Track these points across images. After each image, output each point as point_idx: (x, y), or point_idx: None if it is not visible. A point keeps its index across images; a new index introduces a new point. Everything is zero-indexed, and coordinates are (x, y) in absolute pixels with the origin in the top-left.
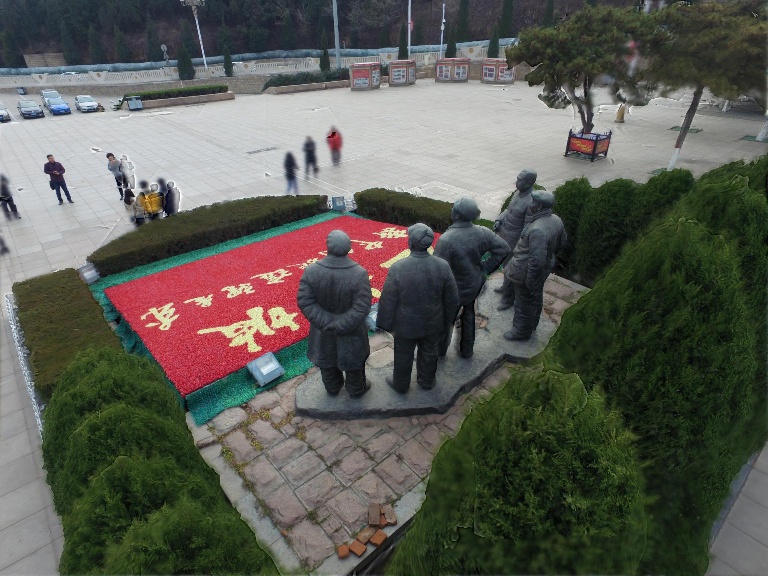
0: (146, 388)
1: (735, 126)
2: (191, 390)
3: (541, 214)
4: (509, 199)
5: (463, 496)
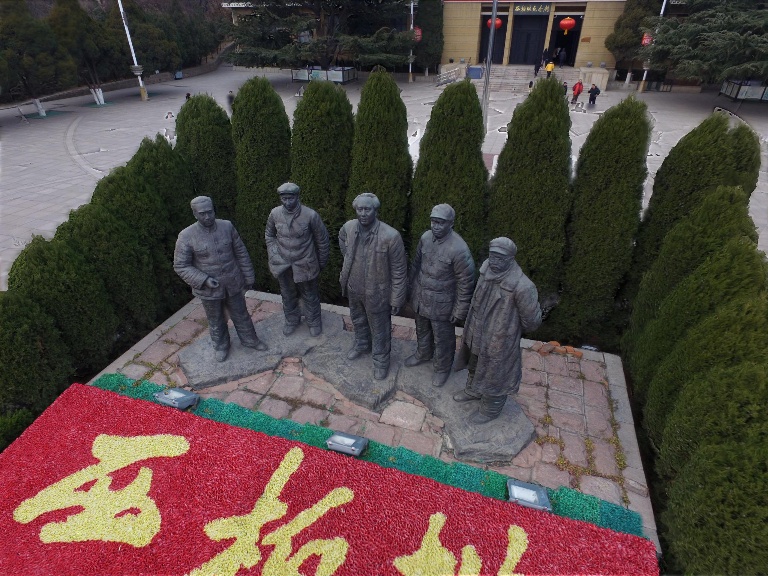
0: (724, 376)
1: None
2: (640, 538)
3: None
4: None
5: (647, 132)
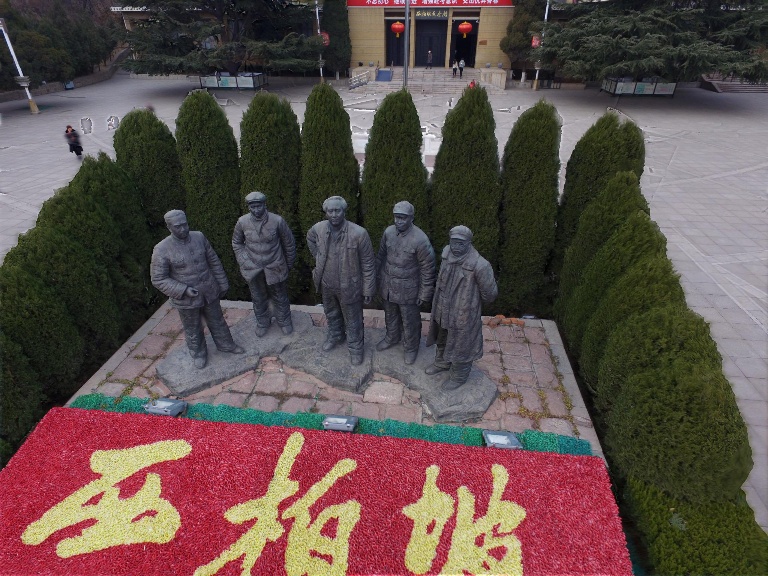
0: (639, 321)
1: None
2: (592, 457)
3: None
4: None
5: None
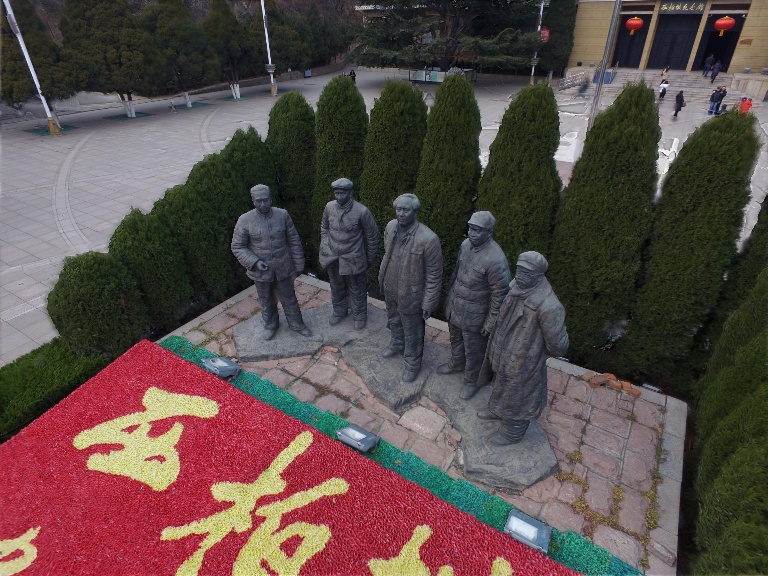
0: None
1: None
2: None
3: None
4: (84, 289)
5: (754, 149)
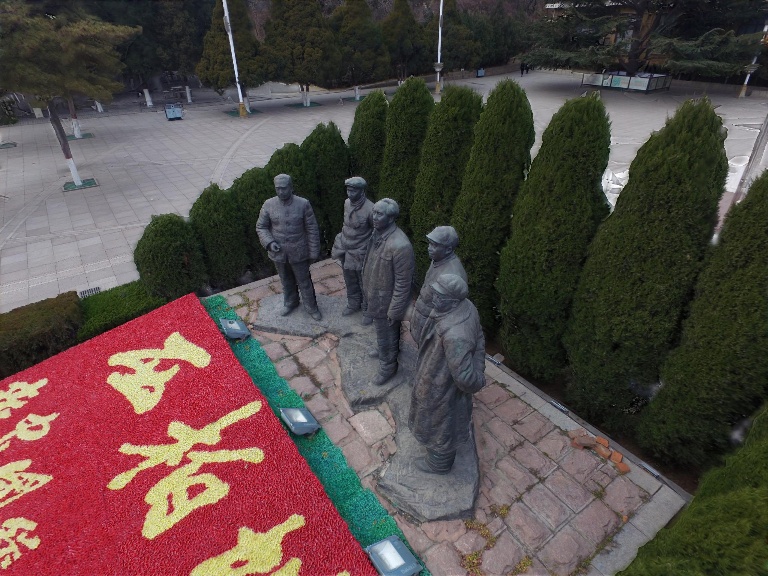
0: (661, 573)
1: (34, 132)
2: None
3: (364, 197)
4: (155, 243)
5: None
